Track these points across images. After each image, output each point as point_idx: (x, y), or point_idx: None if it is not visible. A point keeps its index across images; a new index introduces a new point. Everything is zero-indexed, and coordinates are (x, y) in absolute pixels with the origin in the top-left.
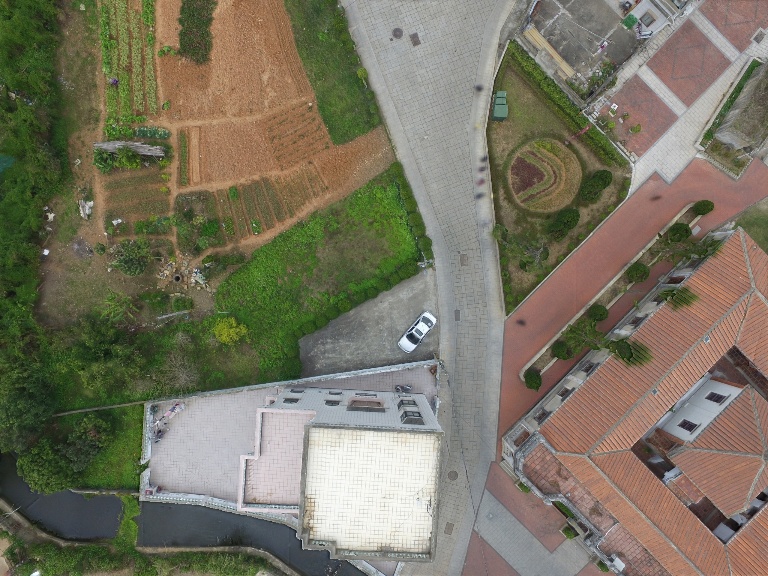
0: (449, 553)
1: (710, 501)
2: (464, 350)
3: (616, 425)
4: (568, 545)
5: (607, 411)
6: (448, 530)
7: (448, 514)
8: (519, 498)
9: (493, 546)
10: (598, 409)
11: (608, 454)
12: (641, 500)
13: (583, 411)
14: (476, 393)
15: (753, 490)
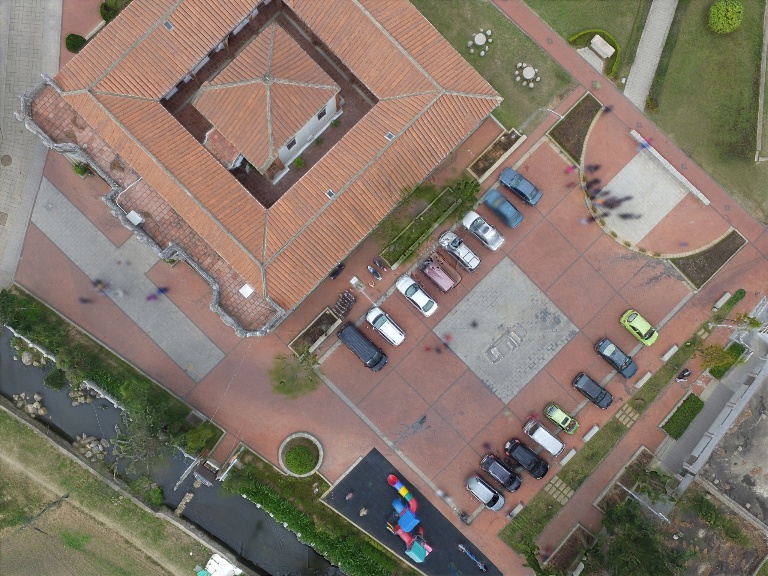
0: (2, 246)
1: (242, 155)
2: (18, 24)
3: (121, 57)
4: (137, 240)
5: (118, 48)
6: (1, 220)
7: (1, 203)
8: (81, 187)
9: (52, 239)
10: (111, 48)
11: (123, 97)
12: (157, 146)
13: (98, 52)
14: (32, 71)
15: (272, 130)
